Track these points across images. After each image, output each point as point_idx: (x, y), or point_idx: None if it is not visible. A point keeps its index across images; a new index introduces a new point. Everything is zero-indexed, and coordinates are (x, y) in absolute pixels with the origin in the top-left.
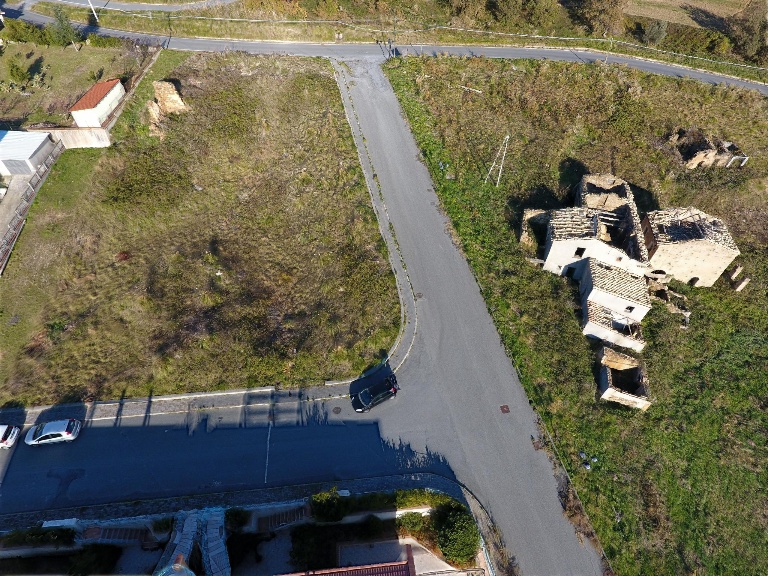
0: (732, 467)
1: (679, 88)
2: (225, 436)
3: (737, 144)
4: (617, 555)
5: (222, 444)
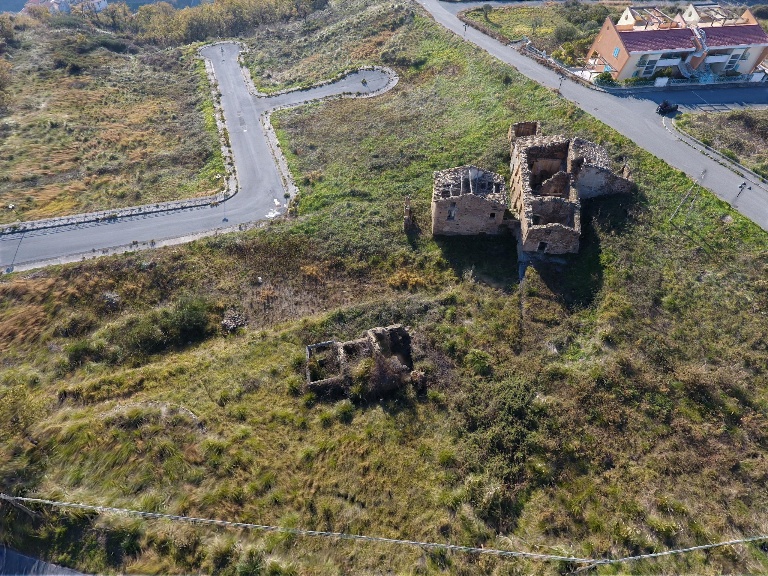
0: (458, 130)
1: (346, 568)
2: (726, 101)
3: (300, 386)
4: (534, 87)
5: (724, 99)
